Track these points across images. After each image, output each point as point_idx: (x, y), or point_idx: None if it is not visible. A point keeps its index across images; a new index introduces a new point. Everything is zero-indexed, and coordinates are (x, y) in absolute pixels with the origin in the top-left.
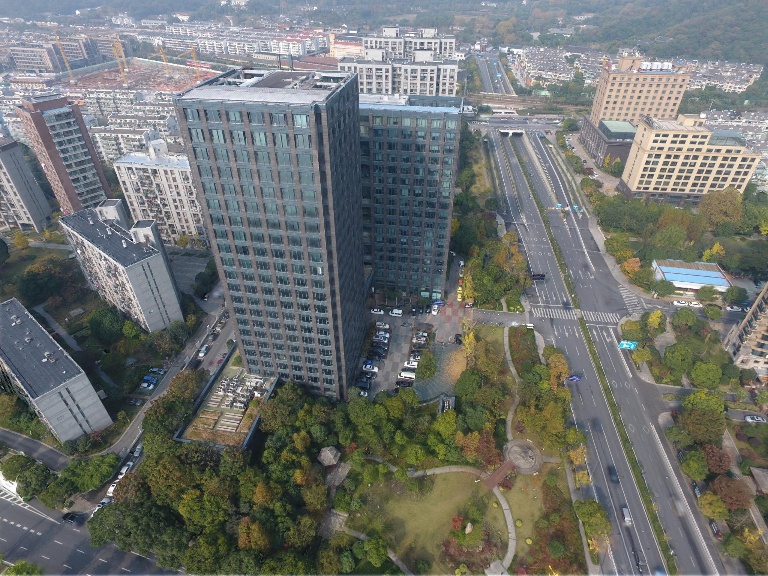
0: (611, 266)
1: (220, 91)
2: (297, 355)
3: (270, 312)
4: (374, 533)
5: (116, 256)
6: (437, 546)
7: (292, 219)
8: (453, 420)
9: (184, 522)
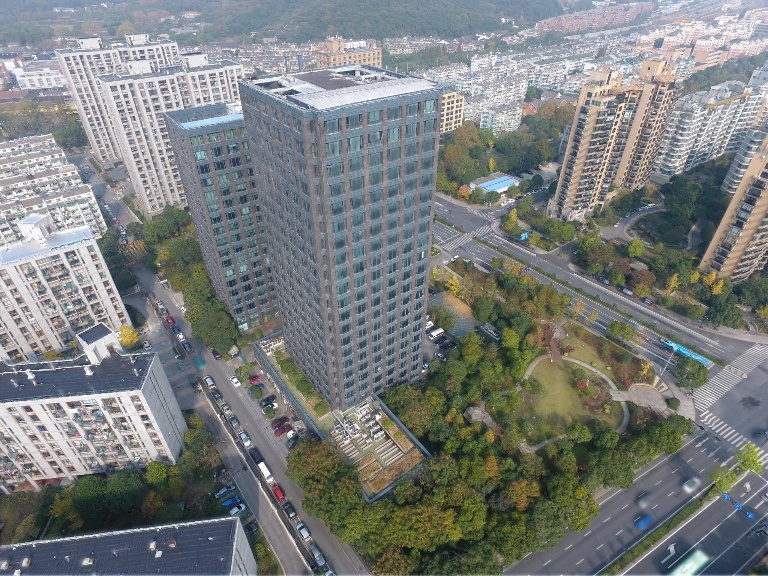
0: (447, 199)
1: (333, 96)
2: (392, 357)
3: (375, 324)
4: (550, 434)
5: (98, 389)
6: (583, 409)
7: (409, 211)
8: (515, 332)
9: (453, 548)
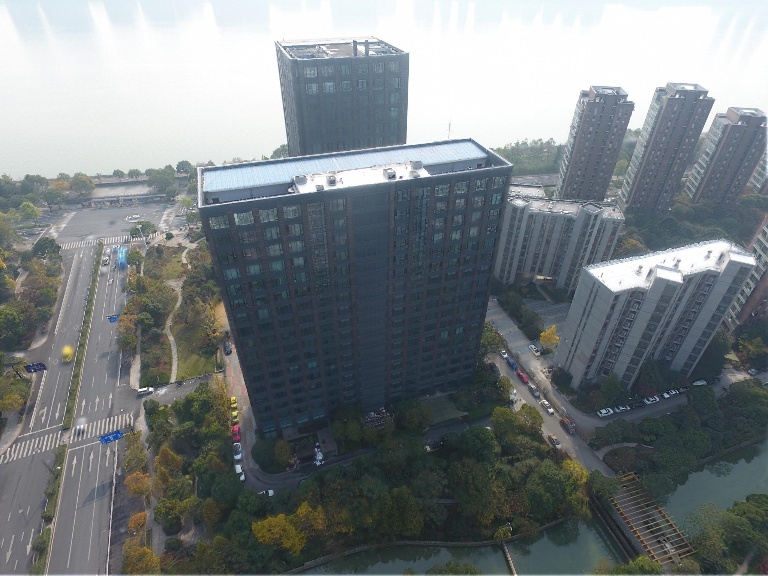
0: None
1: None
2: None
3: None
4: None
5: None
6: None
7: None
8: None
9: None
